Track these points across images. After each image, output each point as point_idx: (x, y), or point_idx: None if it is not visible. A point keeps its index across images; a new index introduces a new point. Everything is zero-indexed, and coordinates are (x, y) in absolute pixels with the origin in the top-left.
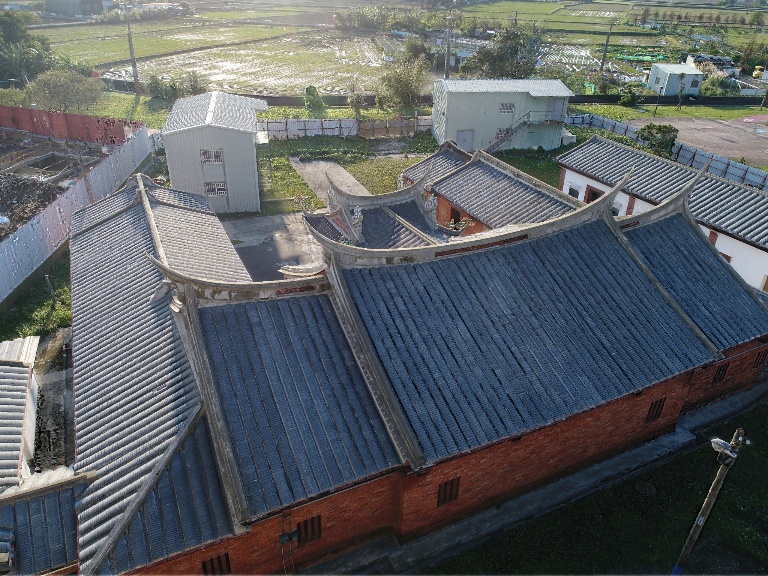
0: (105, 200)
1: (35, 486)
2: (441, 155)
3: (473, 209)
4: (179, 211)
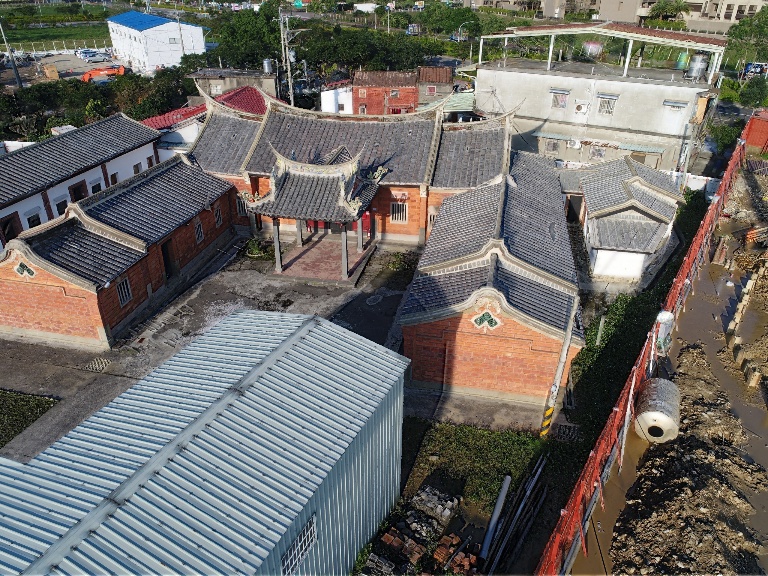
0: (538, 319)
1: (573, 175)
2: (46, 255)
3: (186, 214)
4: (461, 254)
